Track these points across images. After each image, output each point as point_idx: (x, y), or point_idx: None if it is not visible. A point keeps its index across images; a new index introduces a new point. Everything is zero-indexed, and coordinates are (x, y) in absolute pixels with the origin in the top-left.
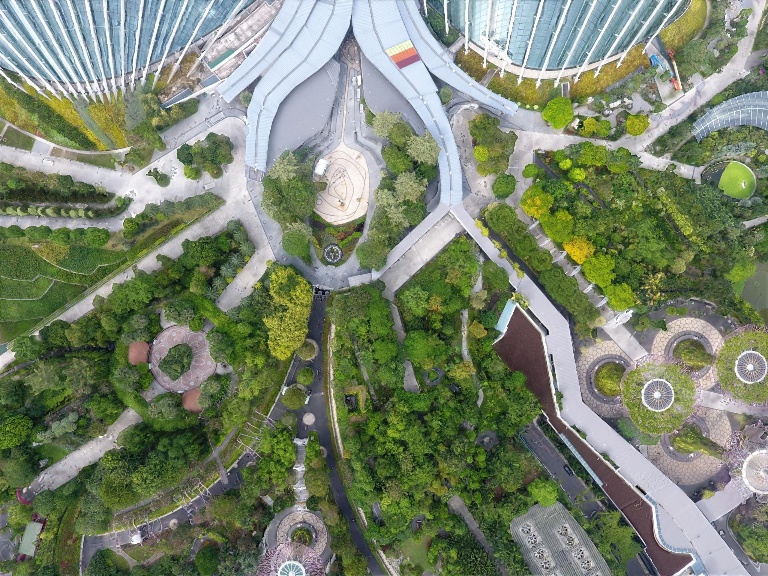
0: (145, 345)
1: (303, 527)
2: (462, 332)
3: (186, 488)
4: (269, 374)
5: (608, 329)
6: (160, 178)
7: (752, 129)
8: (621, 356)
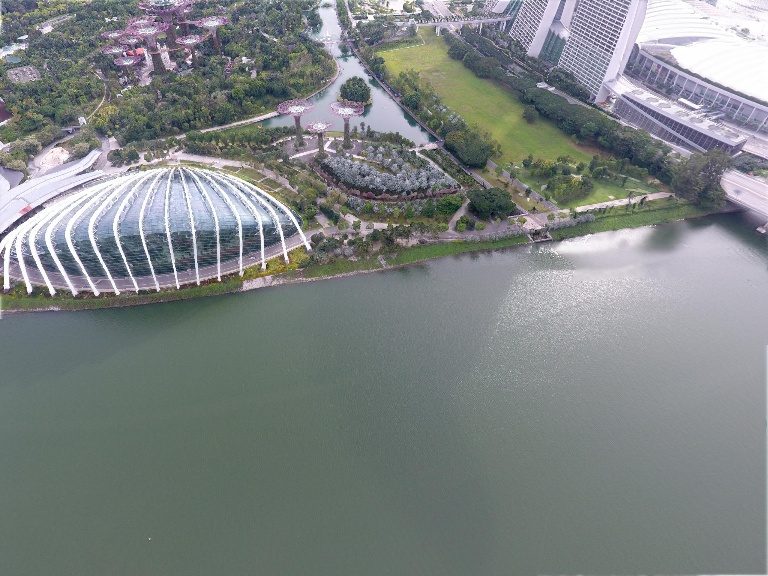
0: None
1: None
2: None
3: None
4: None
5: None
6: (149, 147)
7: None
8: None
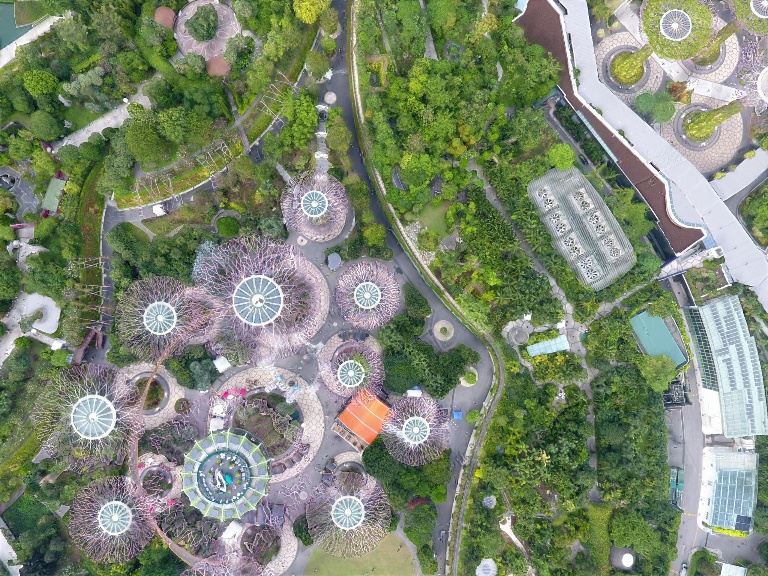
0: (171, 11)
1: None
2: (482, 13)
3: (209, 148)
4: (294, 31)
5: (624, 21)
6: None
7: None
8: (636, 47)
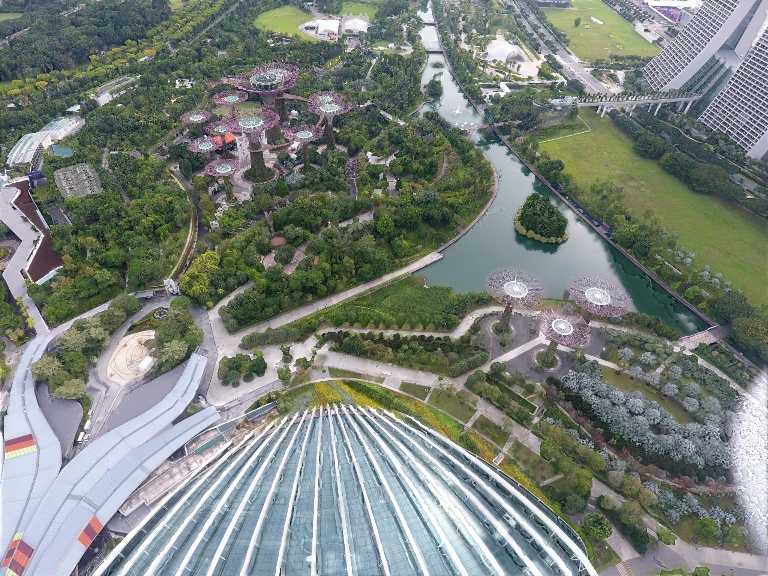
0: None
1: (229, 203)
2: None
3: None
4: None
5: None
6: (281, 347)
7: None
8: None
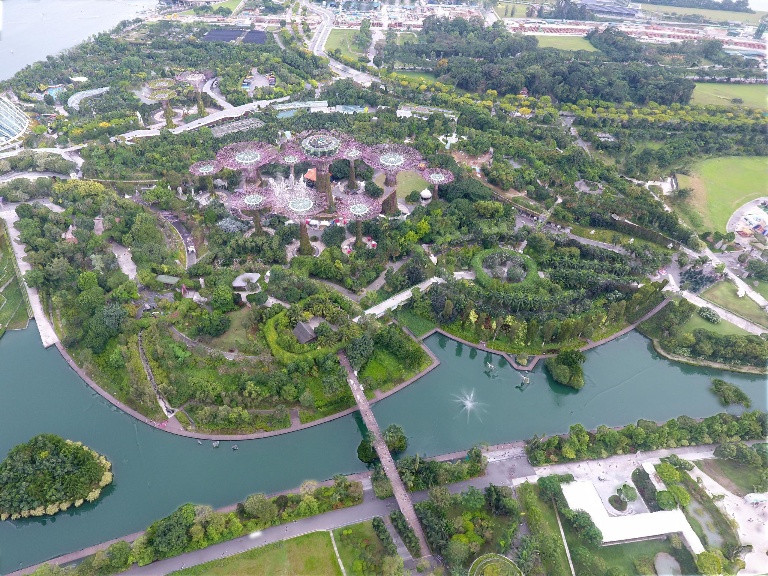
0: None
1: None
2: None
3: None
4: None
5: None
6: None
7: (83, 99)
8: None
